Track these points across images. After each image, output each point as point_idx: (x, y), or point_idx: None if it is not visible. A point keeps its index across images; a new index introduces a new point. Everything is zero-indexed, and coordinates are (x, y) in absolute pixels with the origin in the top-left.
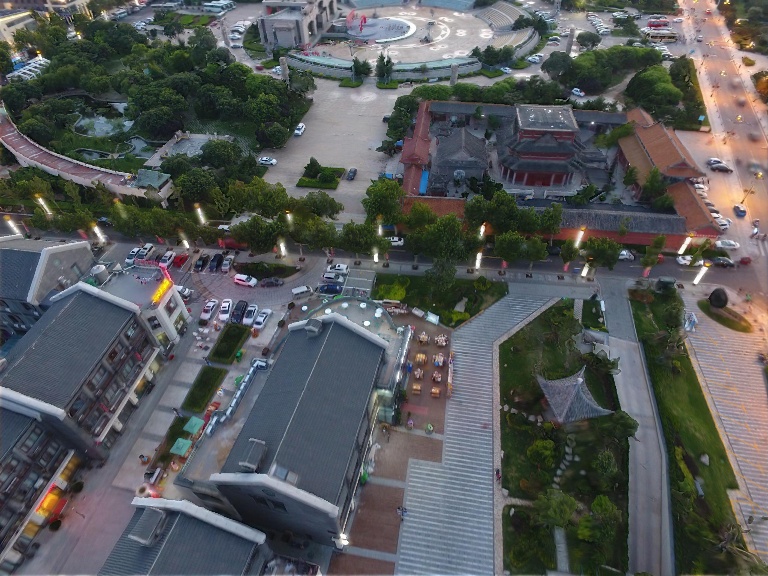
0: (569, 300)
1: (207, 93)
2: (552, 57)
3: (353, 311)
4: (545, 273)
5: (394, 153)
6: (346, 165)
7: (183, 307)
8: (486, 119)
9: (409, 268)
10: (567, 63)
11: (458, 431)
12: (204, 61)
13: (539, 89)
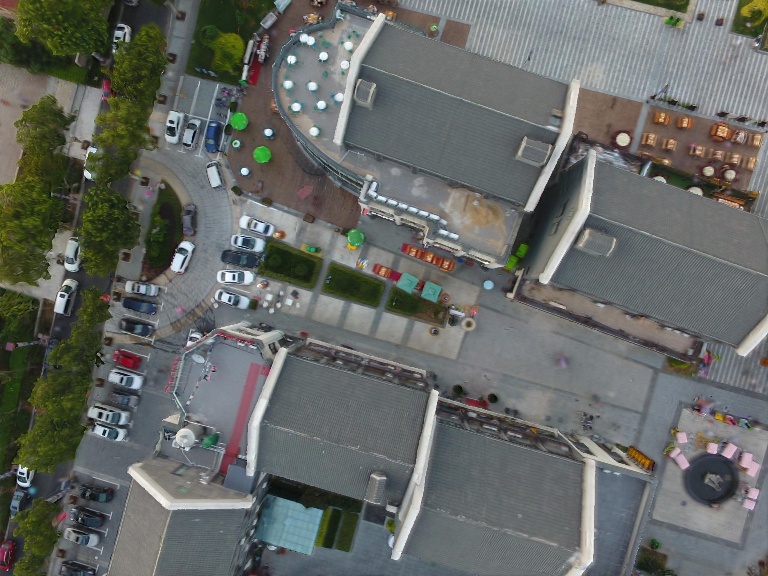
0: None
1: None
2: None
3: (297, 76)
4: None
5: None
6: None
7: (237, 325)
8: None
9: (181, 26)
10: None
11: (439, 1)
12: None
13: None
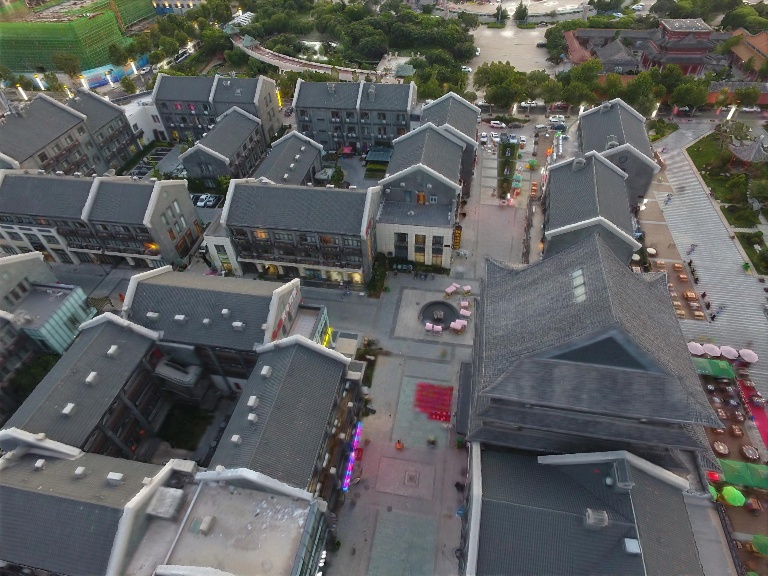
0: (723, 130)
1: (400, 28)
2: (660, 1)
3: None
4: (700, 119)
5: (561, 61)
6: (525, 71)
7: None
8: (621, 41)
9: None
10: (672, 5)
11: (678, 181)
12: (370, 14)
13: (655, 22)
